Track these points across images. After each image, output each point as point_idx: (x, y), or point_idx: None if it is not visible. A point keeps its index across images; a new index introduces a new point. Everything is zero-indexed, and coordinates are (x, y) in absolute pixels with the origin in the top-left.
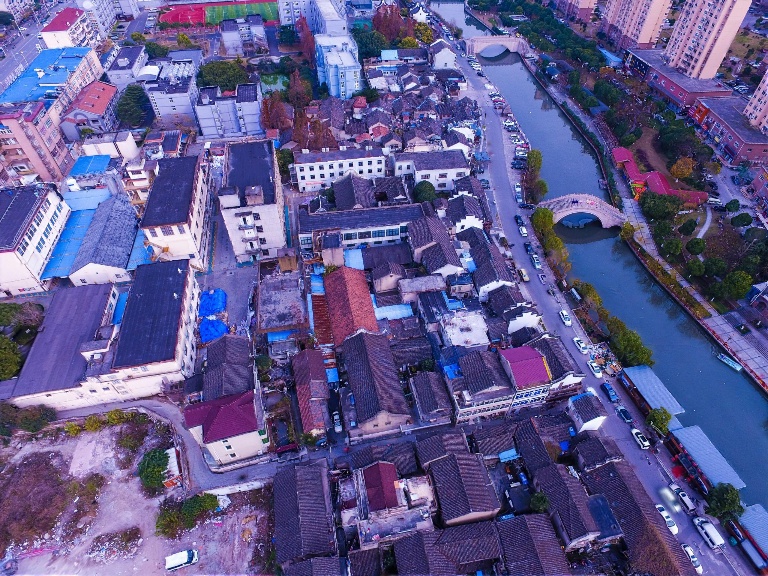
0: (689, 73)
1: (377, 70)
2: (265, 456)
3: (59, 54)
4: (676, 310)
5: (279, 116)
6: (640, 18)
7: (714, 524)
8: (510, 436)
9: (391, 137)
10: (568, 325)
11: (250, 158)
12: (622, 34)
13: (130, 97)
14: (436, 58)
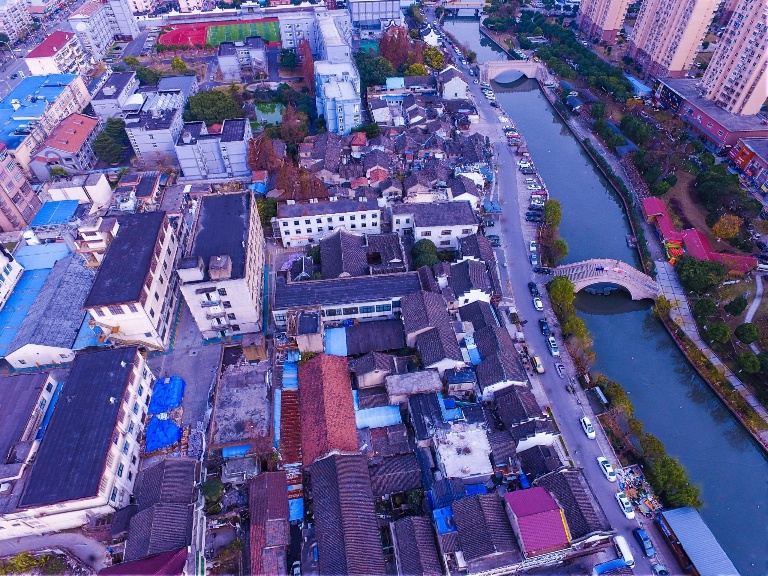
0: (729, 108)
1: (381, 99)
2: None
3: (42, 82)
4: (723, 413)
5: (268, 156)
6: (672, 44)
7: None
8: None
9: (390, 183)
10: (591, 438)
11: (224, 215)
12: (651, 60)
13: (110, 131)
14: (445, 87)
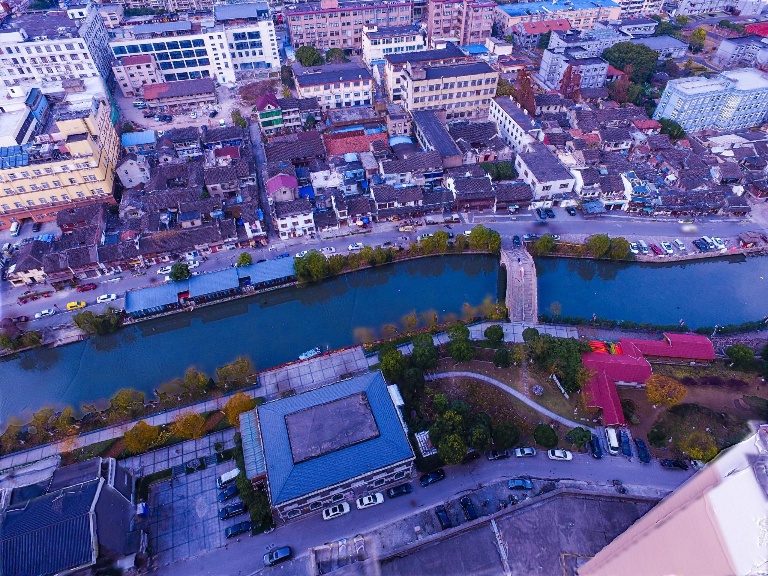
0: None
1: (765, 136)
2: None
3: (597, 1)
4: None
5: None
6: None
7: None
8: (248, 196)
9: None
10: None
11: (470, 70)
12: None
13: None
14: None
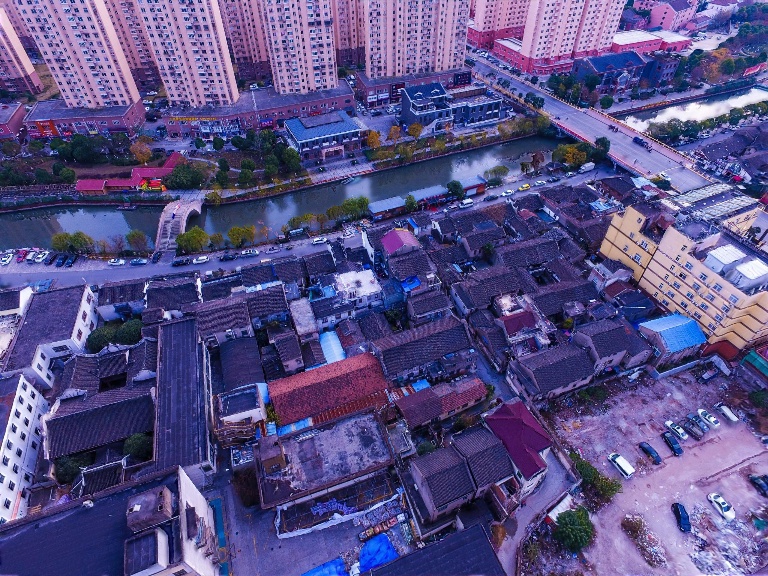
0: None
1: None
2: None
3: None
4: (297, 197)
5: None
6: None
7: None
8: None
9: None
10: None
11: None
12: None
13: None
14: None
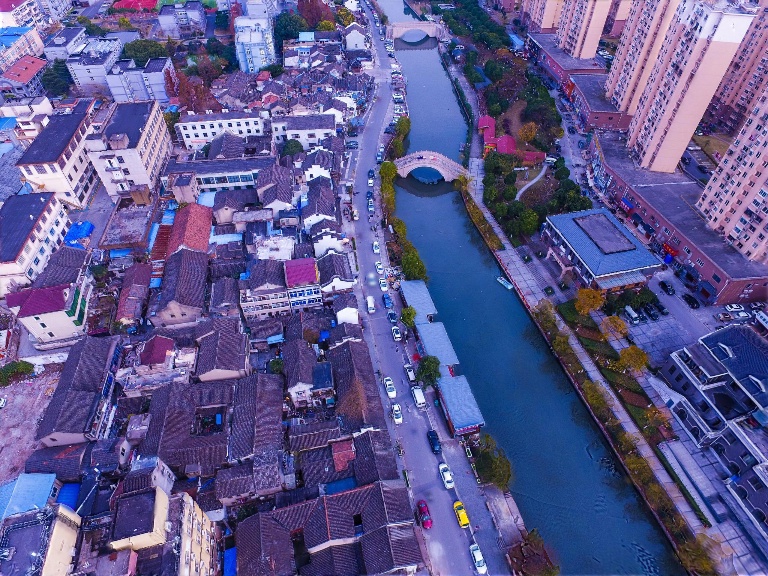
0: (572, 53)
1: (294, 50)
2: (80, 338)
3: (1, 32)
4: None
5: None
6: (542, 5)
7: (429, 392)
8: (279, 325)
9: (276, 104)
10: (376, 253)
11: (131, 115)
12: (531, 20)
13: (57, 69)
14: (347, 39)
